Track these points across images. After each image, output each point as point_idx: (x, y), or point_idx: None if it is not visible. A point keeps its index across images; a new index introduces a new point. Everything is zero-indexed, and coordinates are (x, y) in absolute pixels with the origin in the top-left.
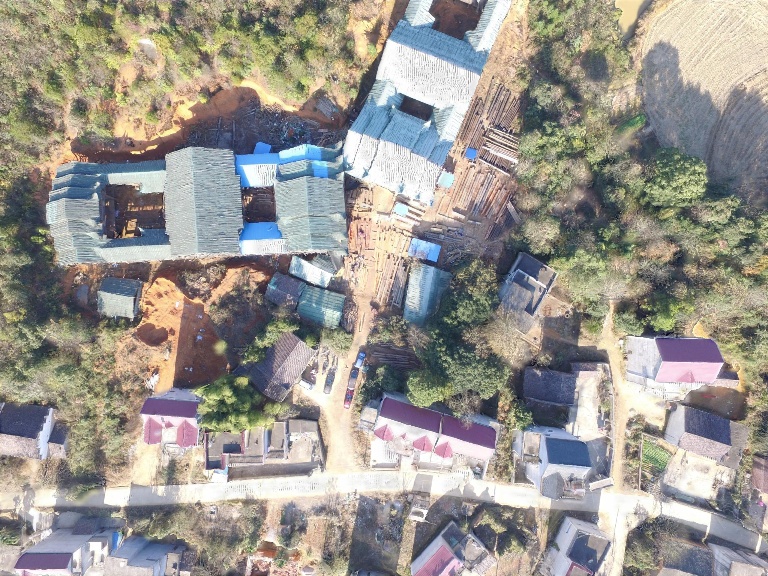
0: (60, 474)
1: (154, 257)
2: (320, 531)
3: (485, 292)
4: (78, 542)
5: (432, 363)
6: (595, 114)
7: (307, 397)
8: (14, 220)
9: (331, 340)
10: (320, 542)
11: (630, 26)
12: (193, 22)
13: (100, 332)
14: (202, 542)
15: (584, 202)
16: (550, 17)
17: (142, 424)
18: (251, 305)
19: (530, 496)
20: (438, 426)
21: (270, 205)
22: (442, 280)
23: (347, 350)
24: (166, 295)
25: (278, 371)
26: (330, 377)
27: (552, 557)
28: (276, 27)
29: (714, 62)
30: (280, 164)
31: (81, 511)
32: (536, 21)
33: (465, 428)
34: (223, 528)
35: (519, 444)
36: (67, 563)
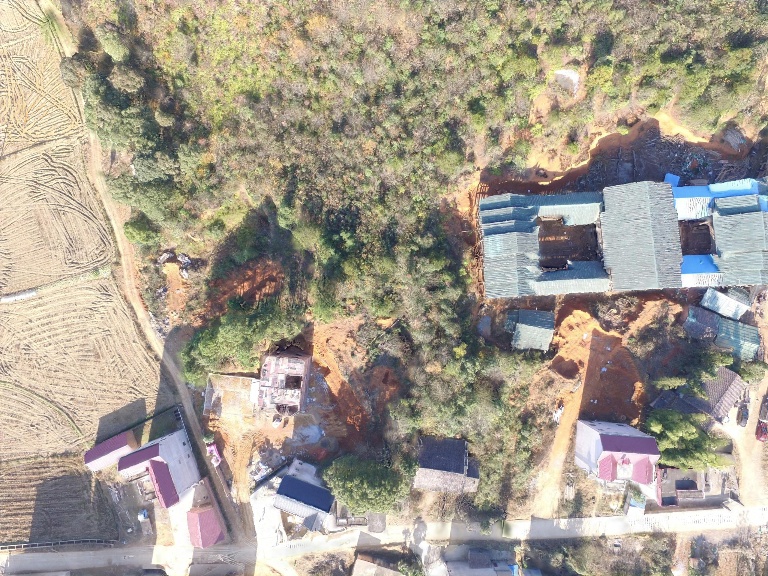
0: (461, 507)
1: (585, 290)
2: (732, 564)
3: None
4: None
5: None
6: None
7: (719, 430)
8: (437, 252)
9: None
10: (731, 575)
11: None
12: (622, 54)
13: (517, 365)
14: (607, 575)
15: None
16: None
17: (546, 457)
18: (668, 338)
19: None
20: None
21: None
22: None
23: (760, 383)
24: (578, 327)
25: (716, 406)
26: (745, 410)
27: None
28: (705, 60)
29: None
30: (716, 198)
31: (478, 544)
32: None
33: None
34: (626, 561)
35: None
36: None
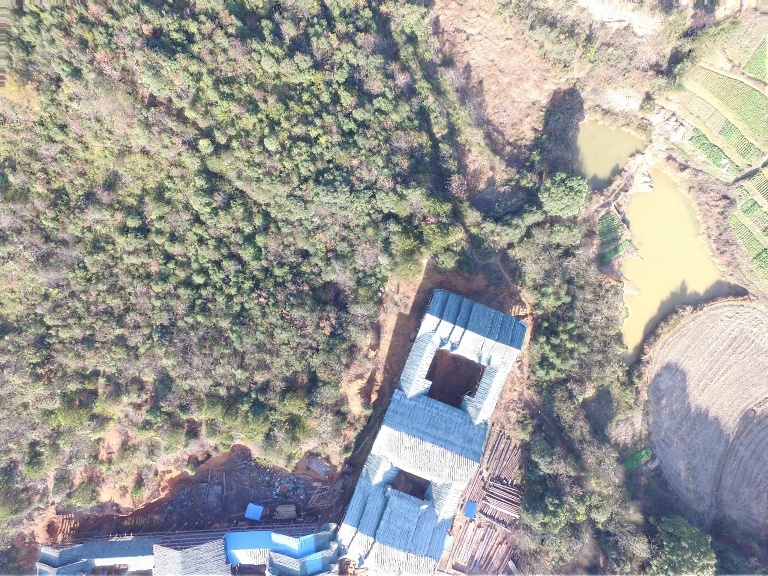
0: None
1: None
2: None
3: None
4: None
5: None
6: (599, 484)
7: None
8: None
9: None
10: None
11: (635, 347)
12: (179, 399)
13: None
14: None
15: (588, 551)
16: (552, 361)
17: None
18: None
19: None
20: None
21: None
22: None
23: None
24: None
25: None
26: None
27: None
28: (266, 403)
29: (723, 386)
30: (272, 551)
31: None
32: (537, 363)
33: None
34: None
35: None
36: None
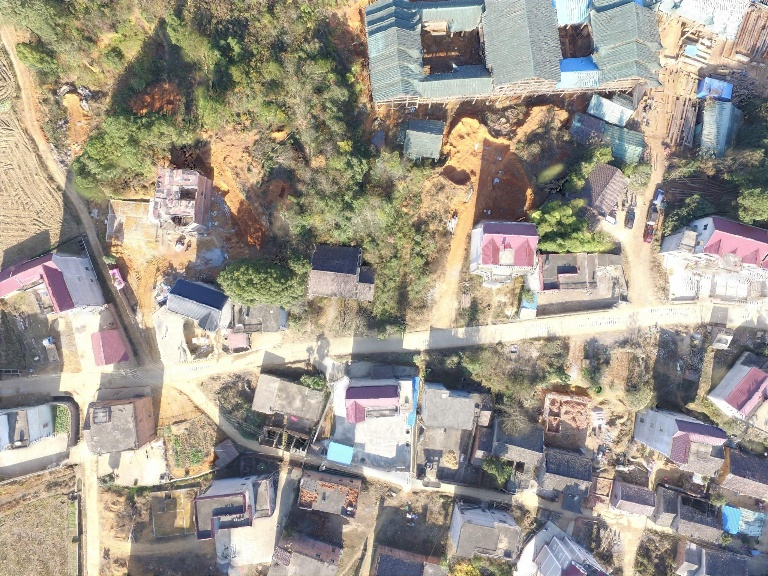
0: (360, 319)
1: (470, 92)
2: (623, 364)
3: None
4: None
5: (762, 179)
6: None
7: (608, 234)
8: None
9: (634, 176)
10: (623, 375)
11: None
12: None
13: (408, 172)
14: (504, 381)
15: None
16: None
17: (442, 267)
18: (555, 143)
19: None
20: None
21: None
22: (736, 116)
23: (646, 187)
24: (468, 136)
25: (598, 199)
26: (632, 212)
27: None
28: None
29: None
30: None
31: (380, 357)
32: None
33: None
34: (523, 367)
35: None
36: (396, 393)
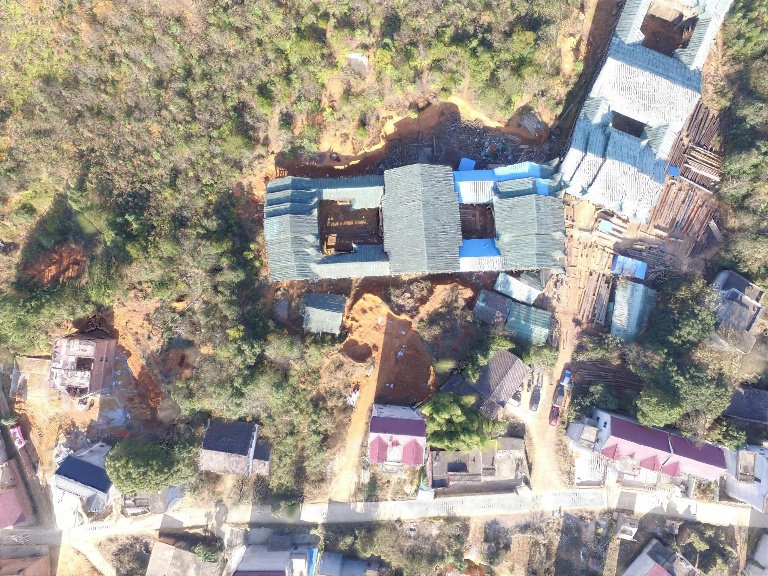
0: (258, 490)
1: (368, 273)
2: (524, 549)
3: (712, 312)
4: (281, 559)
5: (663, 383)
6: None
7: (512, 414)
8: (224, 235)
9: (539, 357)
10: (524, 560)
11: None
12: (408, 37)
13: (307, 348)
14: (402, 559)
15: None
16: (749, 35)
17: (342, 440)
18: (459, 322)
19: (730, 514)
20: (668, 446)
21: (471, 221)
22: (649, 298)
23: (553, 367)
24: (371, 311)
25: (496, 389)
26: (537, 394)
27: (756, 575)
28: (491, 43)
29: None
30: (498, 181)
31: (277, 527)
32: (734, 39)
33: (697, 448)
34: (422, 545)
35: (728, 462)
36: None
